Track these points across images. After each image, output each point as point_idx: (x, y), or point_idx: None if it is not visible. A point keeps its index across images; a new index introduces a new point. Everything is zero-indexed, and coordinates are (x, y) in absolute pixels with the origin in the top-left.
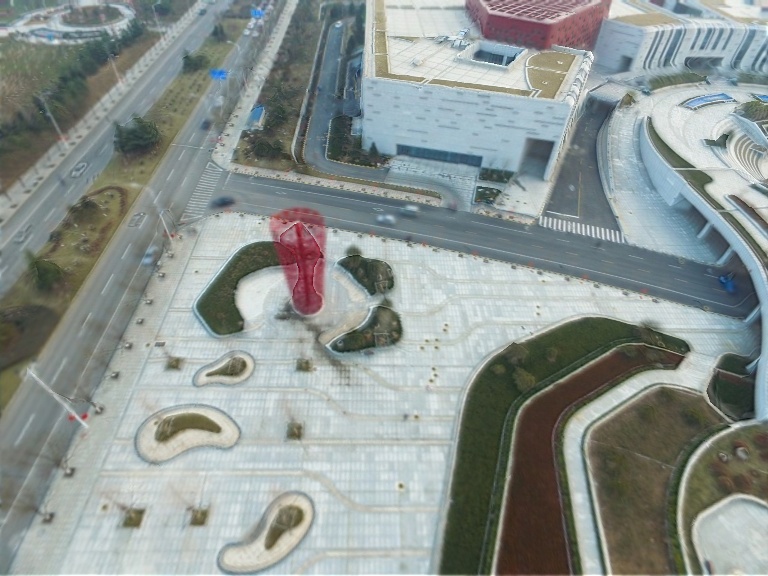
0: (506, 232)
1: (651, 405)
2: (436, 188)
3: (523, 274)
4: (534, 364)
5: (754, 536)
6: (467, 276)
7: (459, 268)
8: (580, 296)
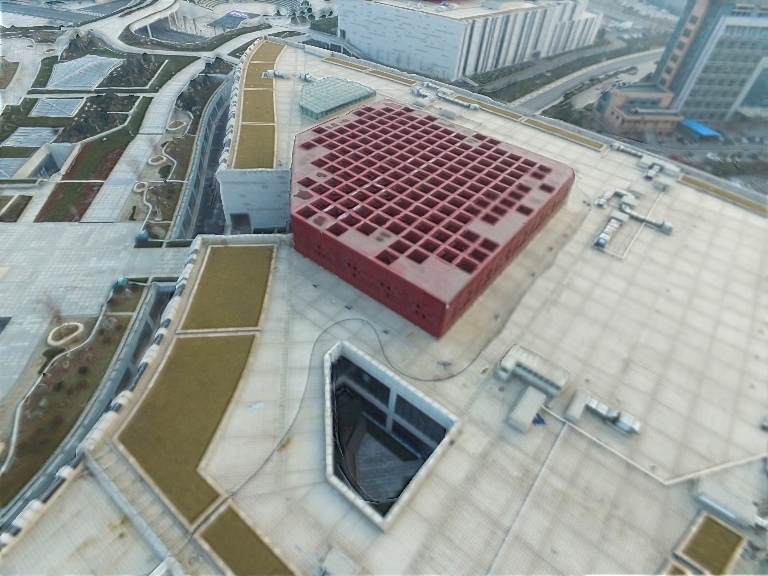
0: (48, 11)
1: (28, 31)
2: (32, 1)
3: (36, 18)
4: (3, 29)
5: (18, 42)
6: (8, 17)
7: (7, 16)
8: (54, 23)
